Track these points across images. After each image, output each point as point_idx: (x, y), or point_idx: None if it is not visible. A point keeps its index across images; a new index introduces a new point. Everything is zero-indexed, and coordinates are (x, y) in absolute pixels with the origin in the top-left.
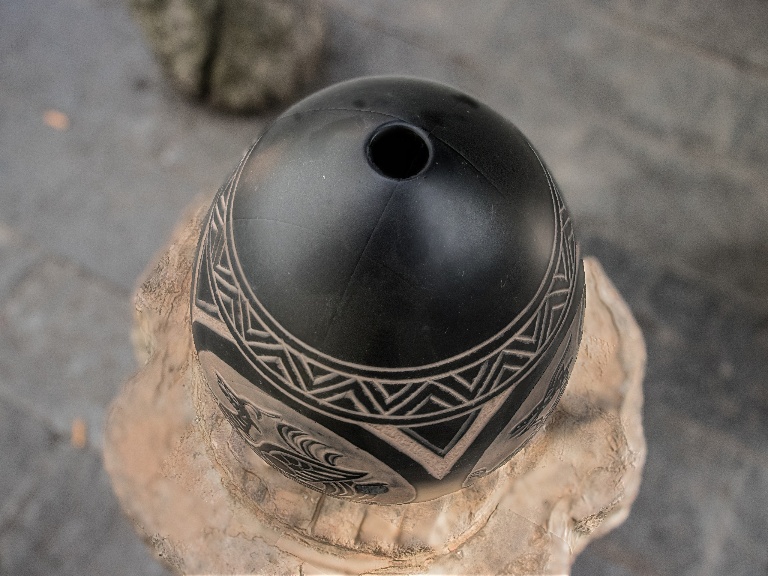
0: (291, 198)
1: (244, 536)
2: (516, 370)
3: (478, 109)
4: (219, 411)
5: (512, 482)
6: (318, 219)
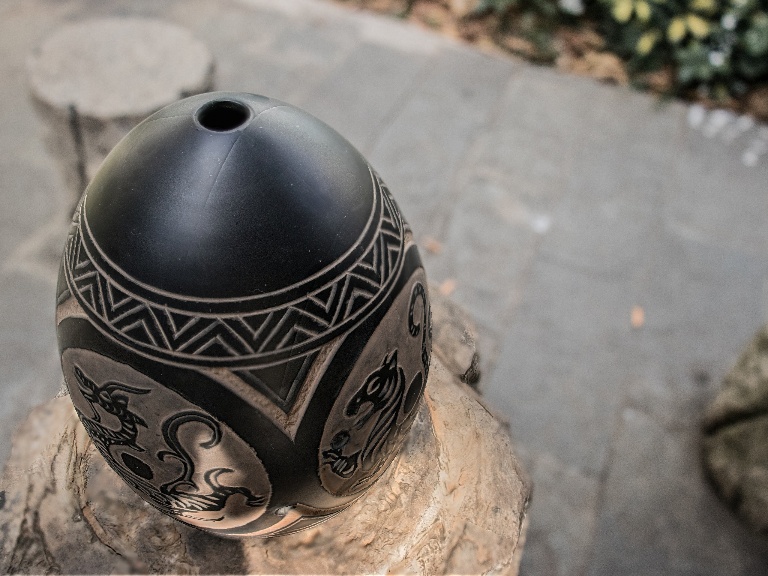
0: None
1: None
2: (93, 305)
3: (307, 203)
4: None
5: (143, 571)
6: None
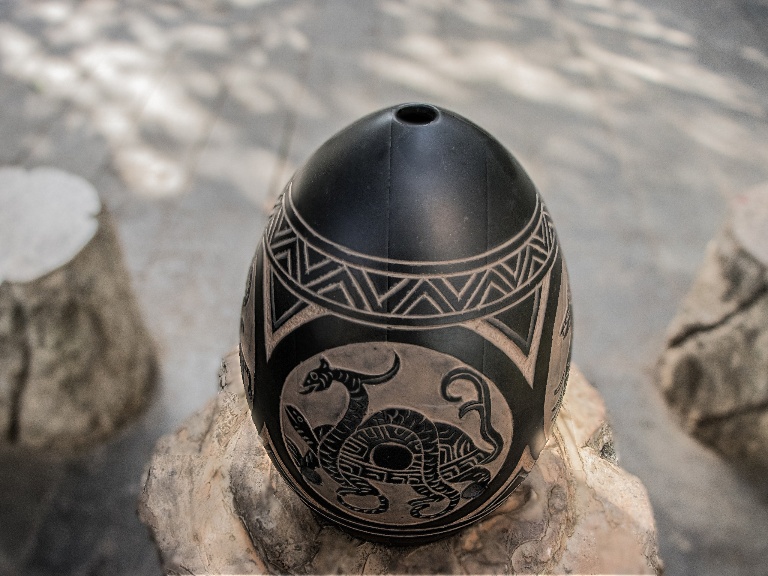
0: (472, 174)
1: (595, 495)
2: None
3: None
4: (521, 564)
5: None
6: (479, 153)
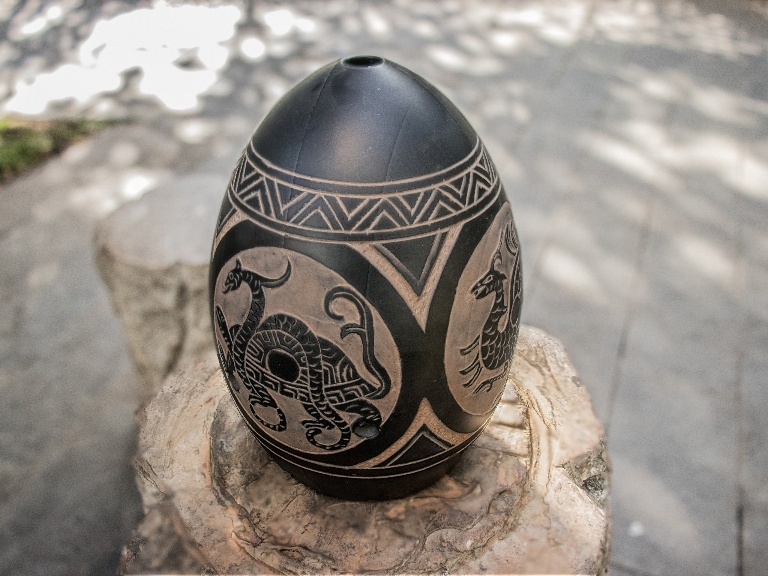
0: (388, 113)
1: (547, 512)
2: None
3: None
4: (435, 545)
5: None
6: (405, 98)
